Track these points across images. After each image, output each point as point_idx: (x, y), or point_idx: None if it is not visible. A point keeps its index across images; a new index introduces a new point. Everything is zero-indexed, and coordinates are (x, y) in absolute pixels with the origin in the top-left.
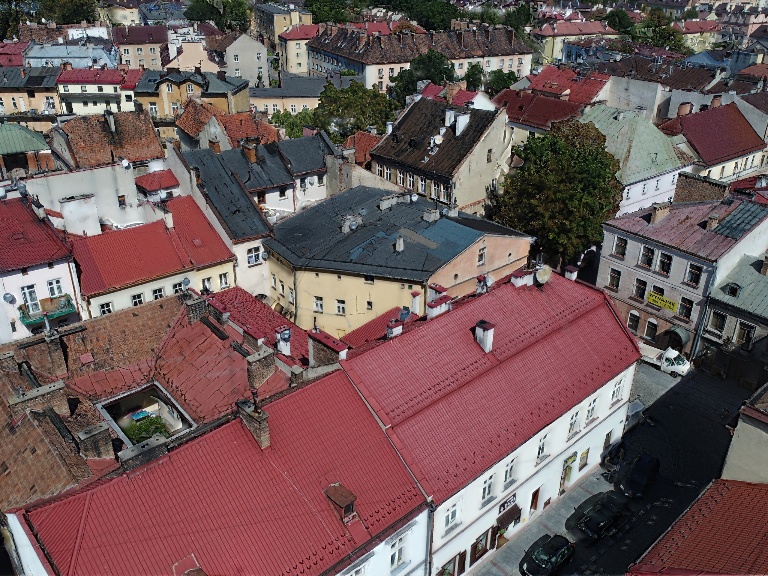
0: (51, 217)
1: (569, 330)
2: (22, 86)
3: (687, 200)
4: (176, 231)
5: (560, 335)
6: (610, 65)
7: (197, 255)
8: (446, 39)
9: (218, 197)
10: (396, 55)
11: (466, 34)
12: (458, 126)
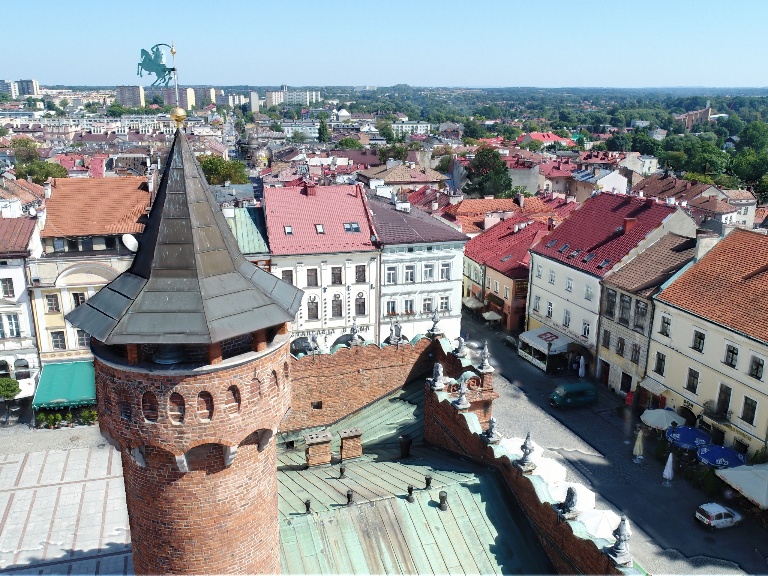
0: None
1: None
2: None
3: (277, 171)
4: None
5: None
6: None
7: None
8: None
9: None
10: None
11: None
12: None
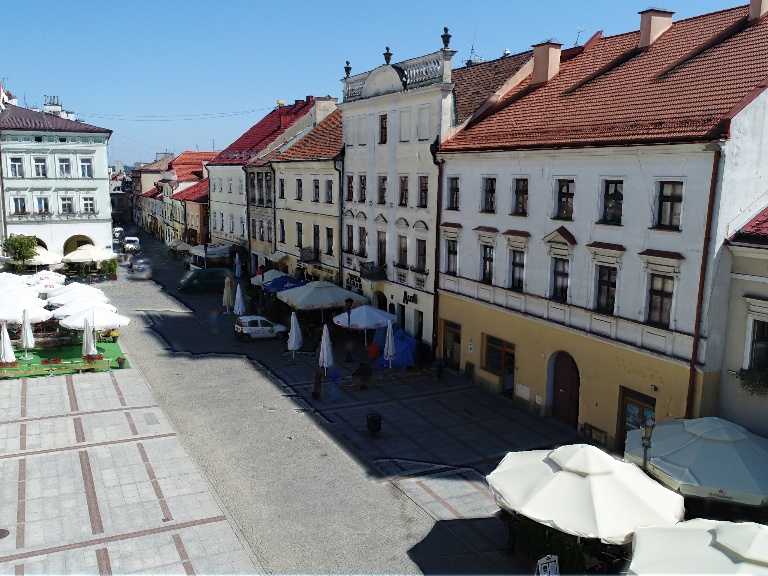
0: None
1: None
2: None
3: None
4: None
5: None
6: None
7: None
8: None
9: None
10: None
11: None
12: None
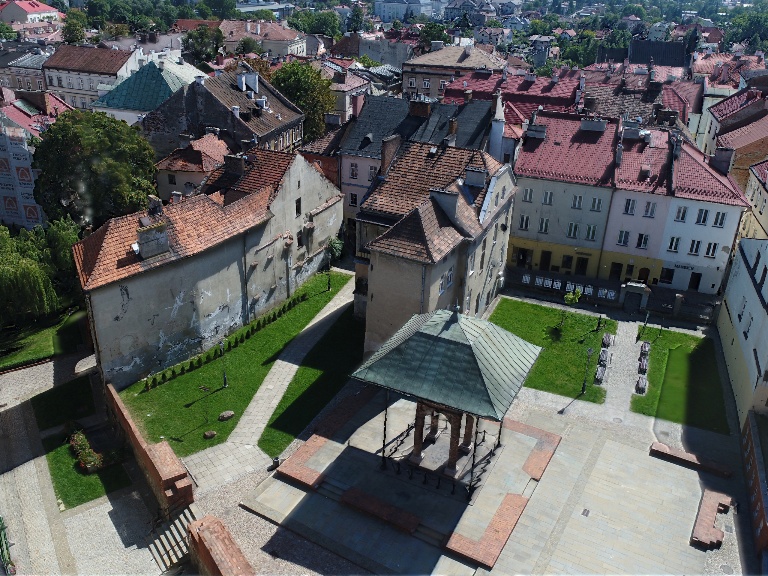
0: None
1: None
2: None
3: None
4: None
5: None
6: None
7: None
8: None
9: None
10: None
11: None
12: None
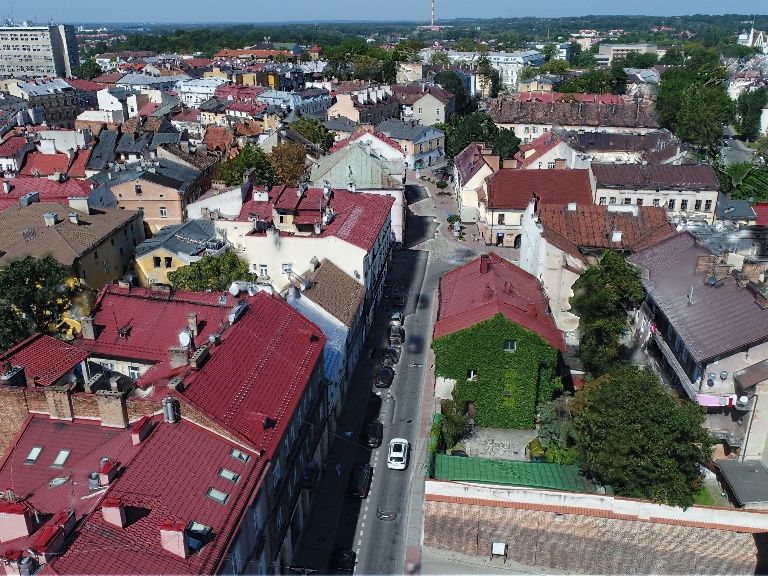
0: (38, 146)
1: (55, 201)
2: (211, 109)
3: None
4: (76, 161)
5: (49, 201)
6: (629, 137)
7: (72, 171)
8: (567, 108)
9: (99, 150)
10: (510, 117)
11: (591, 105)
12: (260, 141)
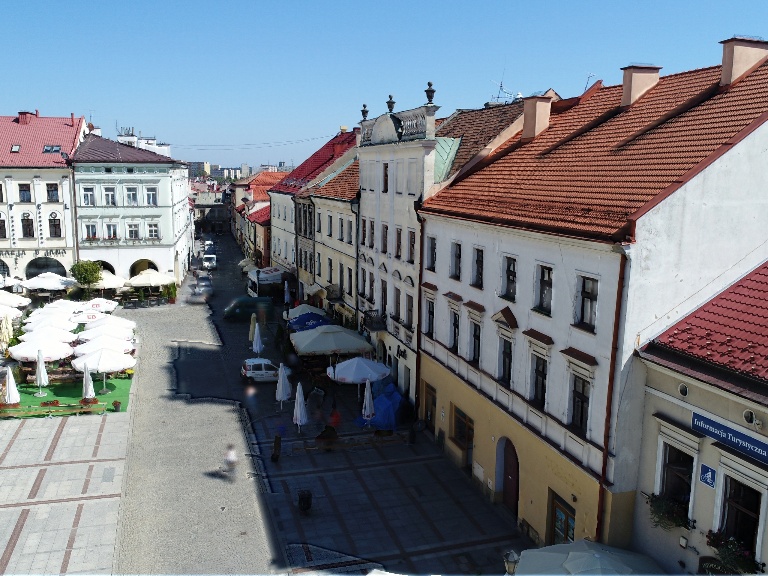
0: None
1: None
2: None
3: None
4: None
5: None
6: None
7: None
8: None
9: None
10: None
11: None
12: None
